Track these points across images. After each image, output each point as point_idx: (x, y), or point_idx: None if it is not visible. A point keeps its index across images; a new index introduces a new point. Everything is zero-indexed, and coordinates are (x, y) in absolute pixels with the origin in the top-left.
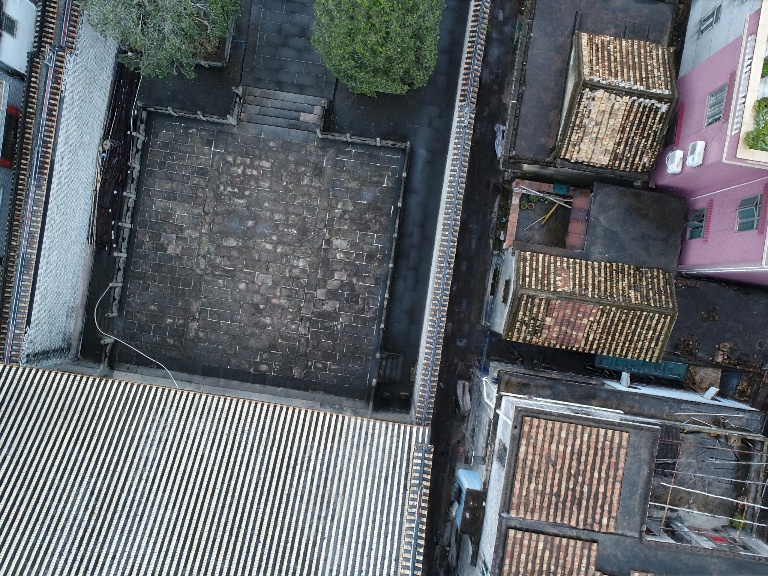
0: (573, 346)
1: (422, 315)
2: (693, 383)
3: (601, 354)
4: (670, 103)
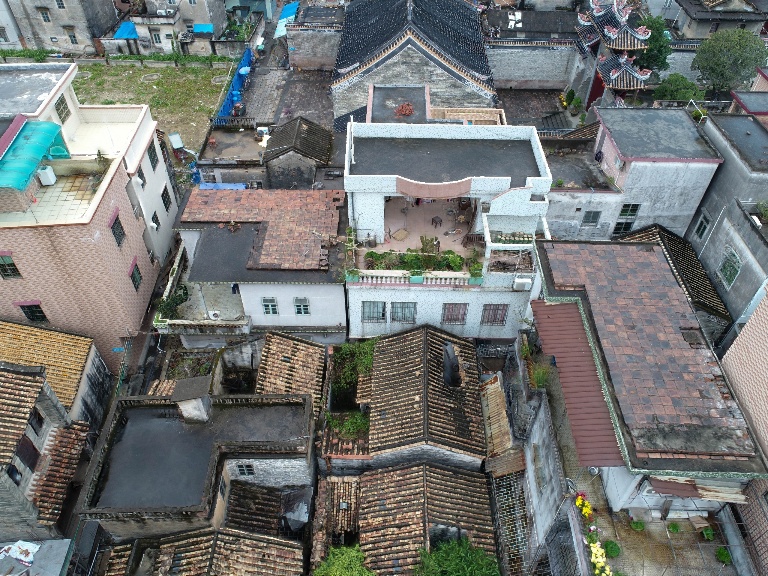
0: None
1: None
2: None
3: None
4: None
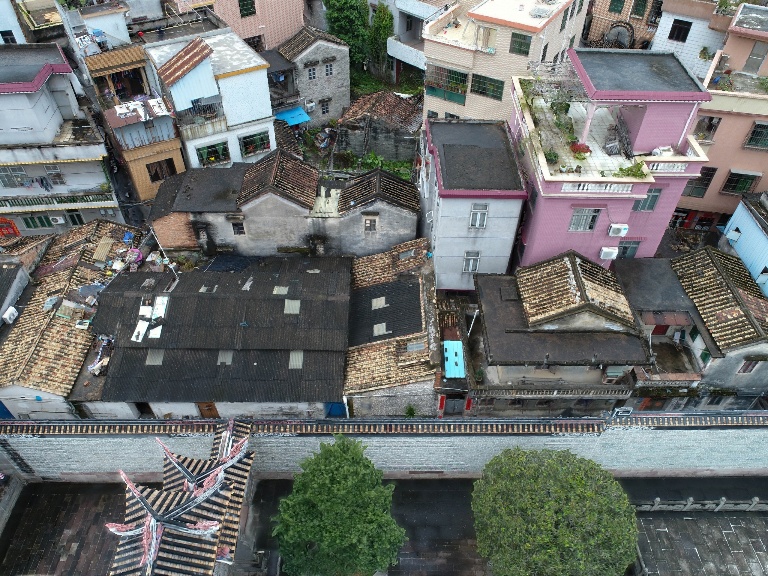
0: None
1: (765, 479)
2: None
3: None
4: (575, 256)
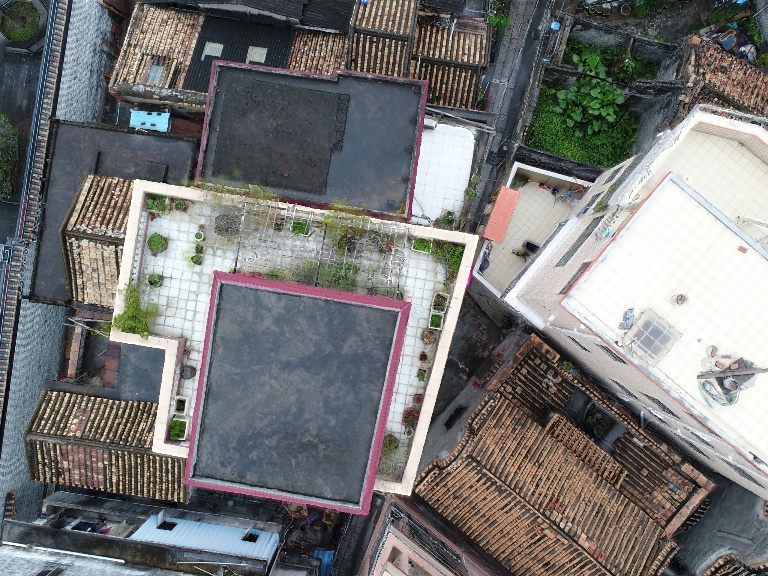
0: (98, 487)
1: None
2: (286, 504)
3: (130, 494)
4: None
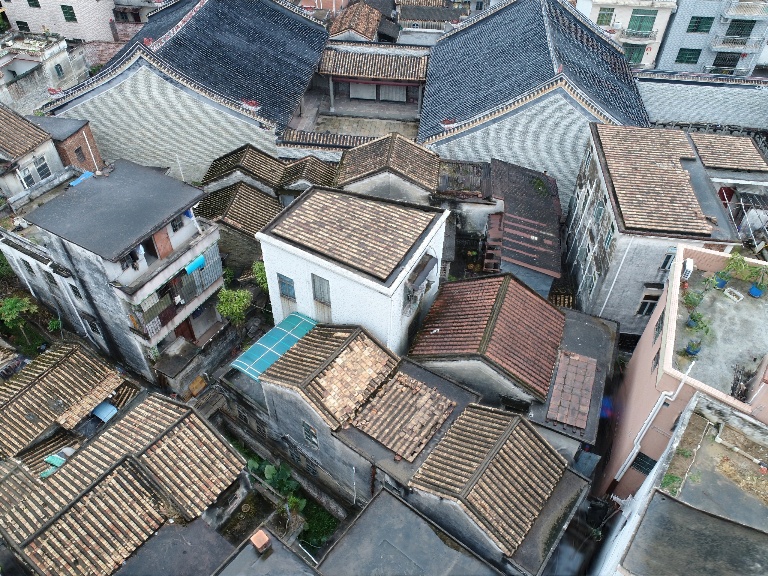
0: None
1: None
2: None
3: None
4: None
